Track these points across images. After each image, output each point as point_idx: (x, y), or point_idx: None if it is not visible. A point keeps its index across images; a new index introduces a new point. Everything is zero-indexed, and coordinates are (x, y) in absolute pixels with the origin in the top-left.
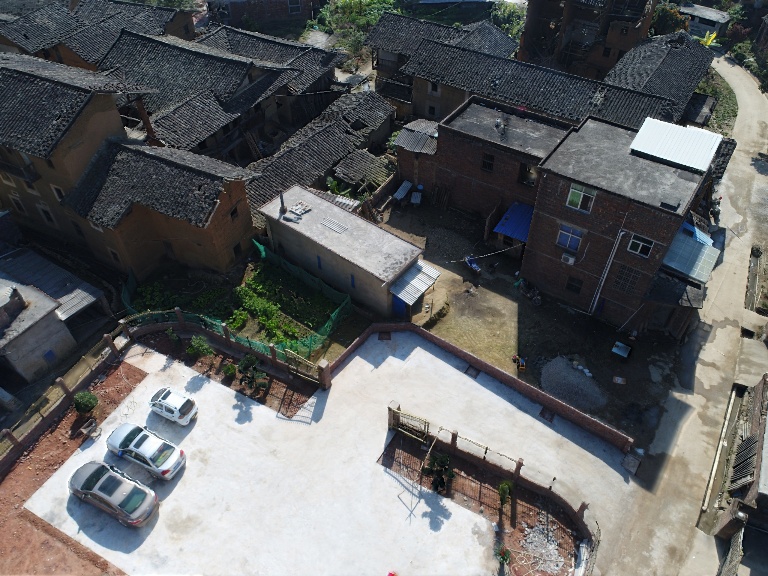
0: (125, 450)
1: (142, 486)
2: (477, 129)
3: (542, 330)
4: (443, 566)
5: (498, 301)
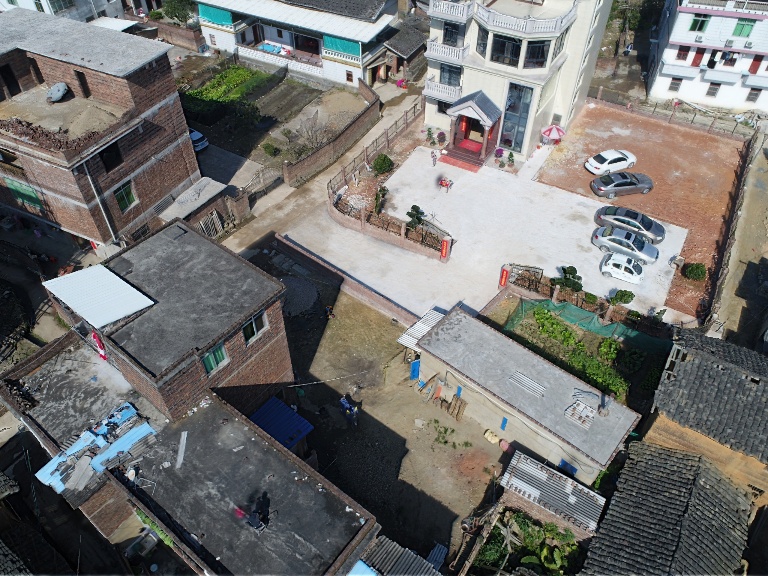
0: (638, 236)
1: (611, 218)
2: (304, 515)
3: (295, 342)
4: (417, 197)
5: (329, 376)
